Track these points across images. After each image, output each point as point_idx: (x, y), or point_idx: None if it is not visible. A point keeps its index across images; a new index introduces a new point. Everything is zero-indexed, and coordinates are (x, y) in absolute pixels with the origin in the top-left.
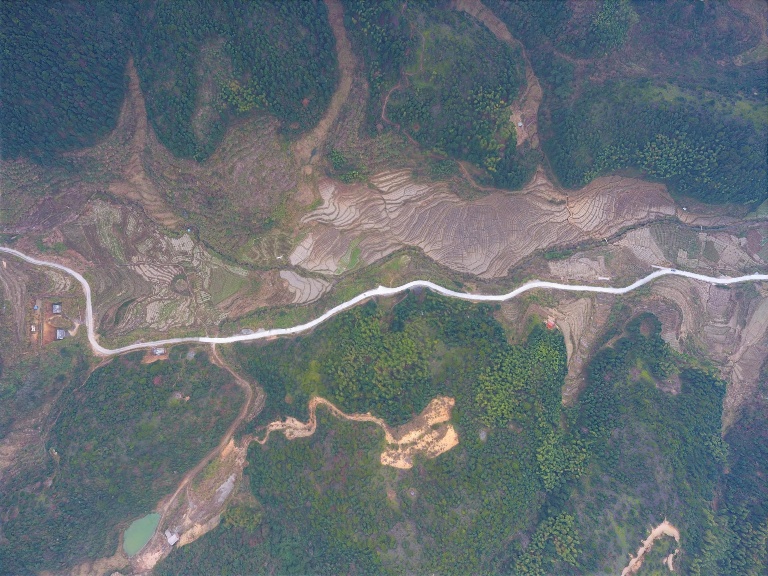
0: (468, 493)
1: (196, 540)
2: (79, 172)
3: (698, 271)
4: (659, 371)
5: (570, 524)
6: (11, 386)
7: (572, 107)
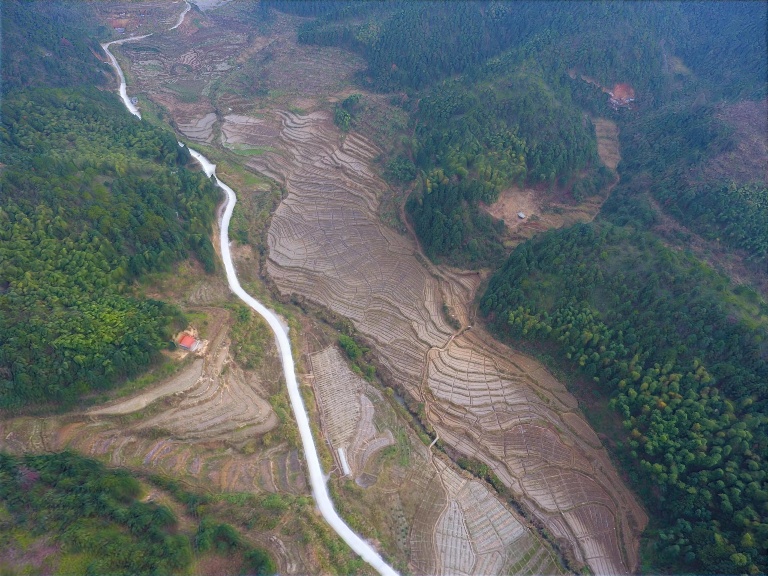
0: None
1: None
2: (265, 21)
3: None
4: None
5: None
6: (66, 4)
7: (598, 232)
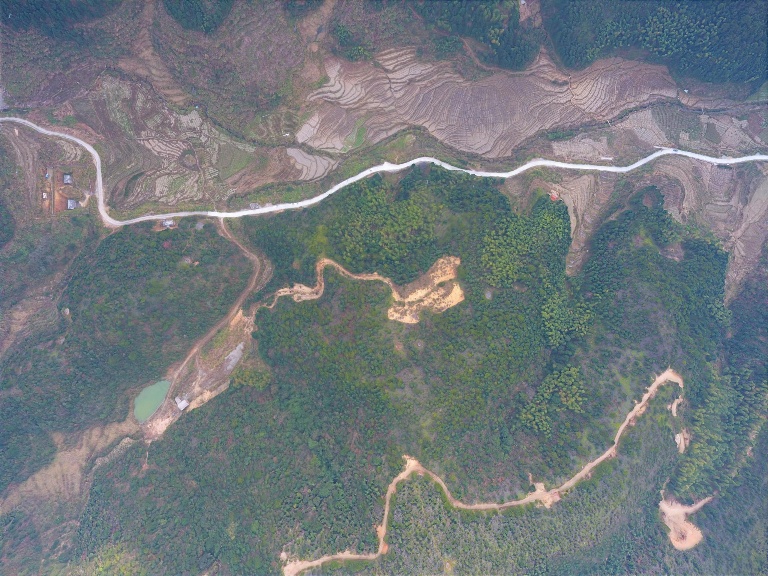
0: (474, 339)
1: (206, 402)
2: (89, 46)
3: (700, 151)
4: (662, 237)
5: (575, 375)
6: (23, 248)
7: None
